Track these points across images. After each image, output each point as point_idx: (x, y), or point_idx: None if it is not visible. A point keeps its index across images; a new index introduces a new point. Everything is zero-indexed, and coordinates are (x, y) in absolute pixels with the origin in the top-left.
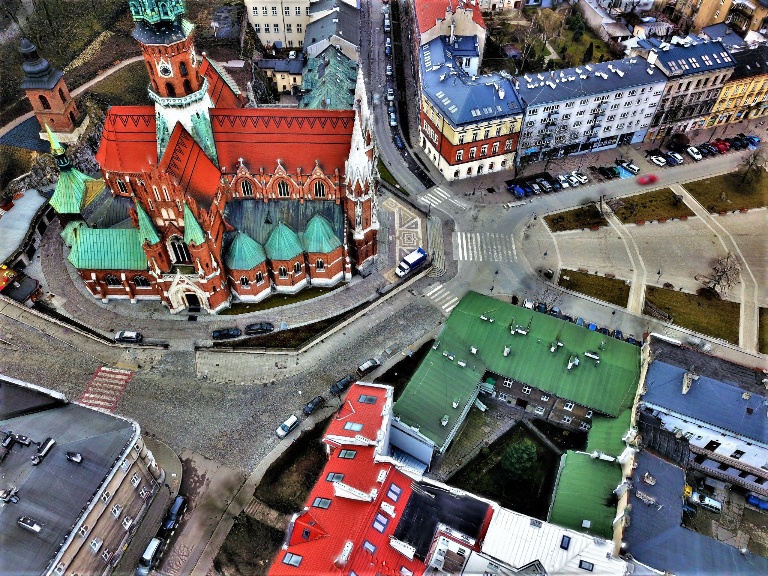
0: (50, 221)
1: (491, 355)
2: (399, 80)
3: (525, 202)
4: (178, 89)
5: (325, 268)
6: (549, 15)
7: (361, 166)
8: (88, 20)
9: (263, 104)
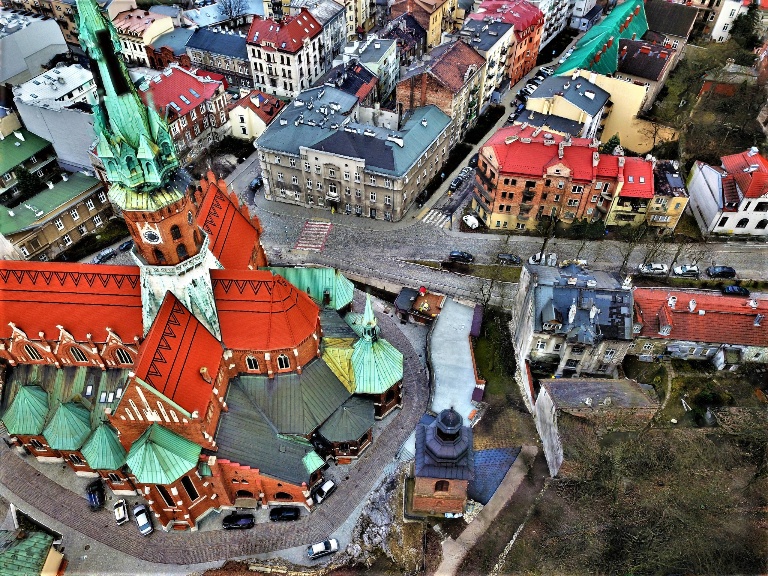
0: None
1: (1, 212)
2: None
3: None
4: None
5: None
6: None
7: None
8: None
9: None
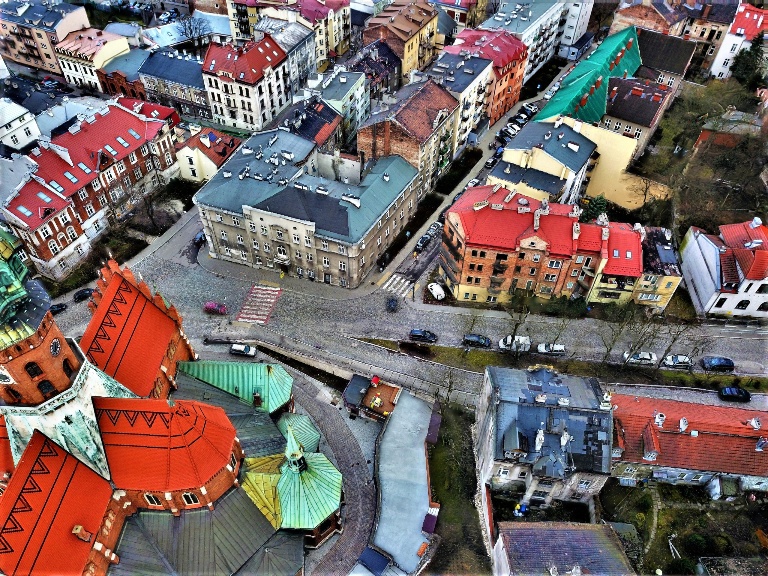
0: None
1: None
2: None
3: None
4: None
5: None
6: None
7: None
8: None
9: None
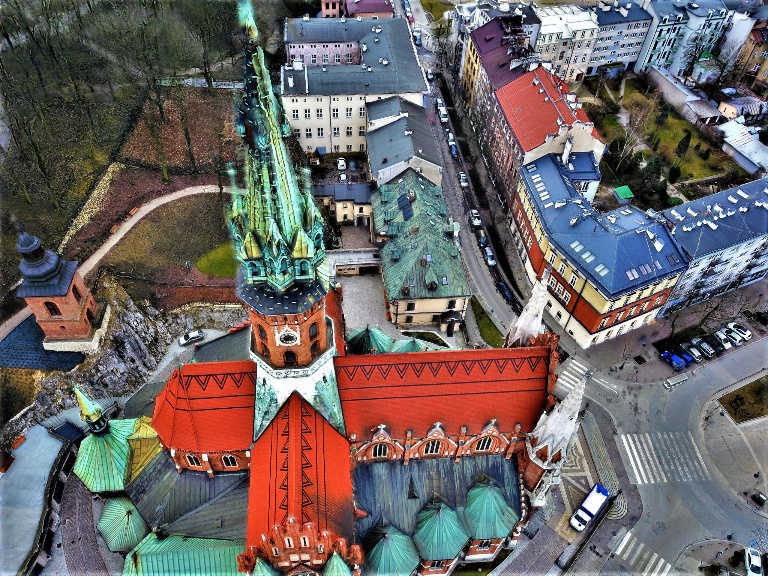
0: (68, 473)
1: None
2: (479, 193)
3: (687, 376)
4: (303, 356)
5: (490, 546)
6: (641, 102)
7: (569, 435)
8: (88, 150)
9: (329, 250)
